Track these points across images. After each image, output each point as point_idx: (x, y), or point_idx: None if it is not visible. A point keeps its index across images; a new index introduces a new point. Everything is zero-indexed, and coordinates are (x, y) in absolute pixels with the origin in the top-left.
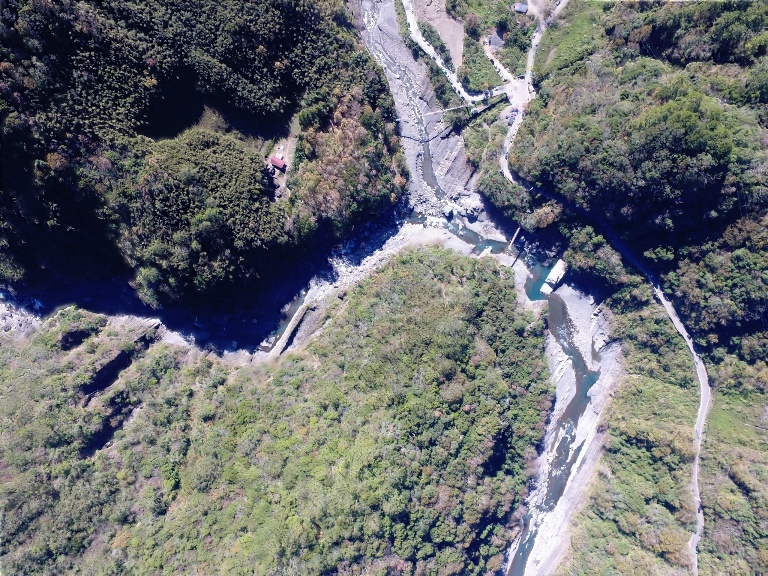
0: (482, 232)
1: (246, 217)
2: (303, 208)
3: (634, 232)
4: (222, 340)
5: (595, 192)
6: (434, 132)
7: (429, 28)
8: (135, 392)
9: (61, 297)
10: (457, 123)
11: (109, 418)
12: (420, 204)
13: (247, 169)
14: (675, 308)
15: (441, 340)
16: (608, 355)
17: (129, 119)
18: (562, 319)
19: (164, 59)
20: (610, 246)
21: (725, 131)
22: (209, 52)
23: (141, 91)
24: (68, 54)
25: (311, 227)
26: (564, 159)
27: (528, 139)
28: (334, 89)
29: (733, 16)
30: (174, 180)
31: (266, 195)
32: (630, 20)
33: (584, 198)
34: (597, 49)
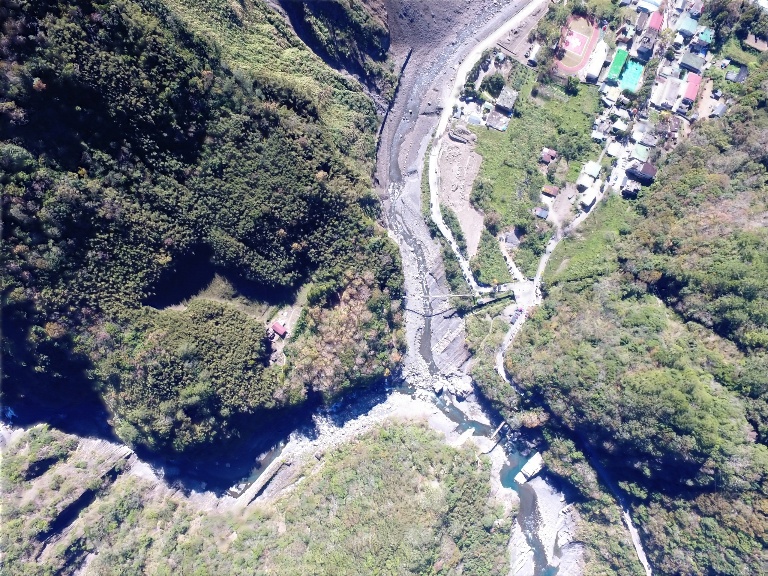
0: (468, 412)
1: (237, 386)
2: (296, 379)
3: (613, 462)
4: (192, 478)
5: (582, 420)
6: (438, 309)
7: (450, 214)
8: (93, 538)
9: (36, 410)
10: (462, 308)
11: (61, 571)
12: (412, 376)
13: (247, 339)
14: (640, 536)
15: (408, 553)
16: (569, 553)
17: (137, 292)
18: (531, 510)
19: (183, 238)
20: (588, 463)
21: (712, 426)
22: (229, 232)
23: (154, 266)
24: (87, 236)
25: (300, 400)
26: (557, 382)
27: (527, 348)
28: (347, 269)
29: (738, 303)
30: (171, 356)
31: (261, 361)
32: (642, 259)
33: (571, 419)
34: (607, 272)
